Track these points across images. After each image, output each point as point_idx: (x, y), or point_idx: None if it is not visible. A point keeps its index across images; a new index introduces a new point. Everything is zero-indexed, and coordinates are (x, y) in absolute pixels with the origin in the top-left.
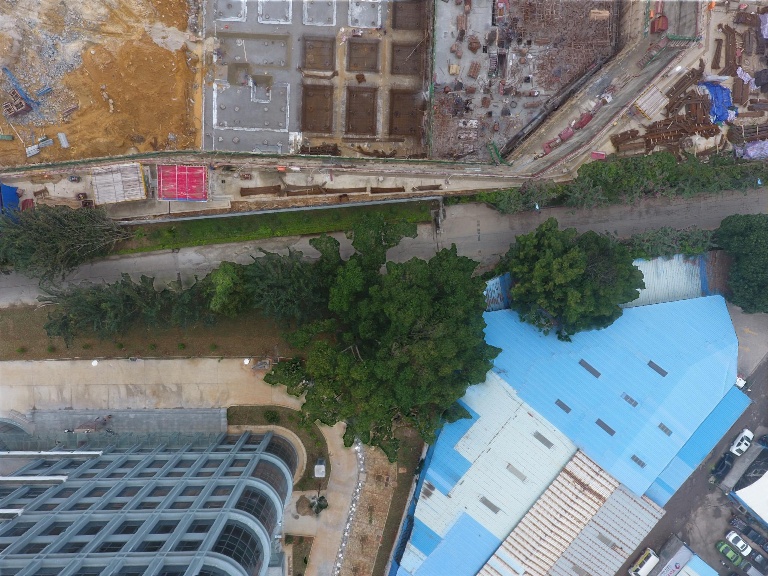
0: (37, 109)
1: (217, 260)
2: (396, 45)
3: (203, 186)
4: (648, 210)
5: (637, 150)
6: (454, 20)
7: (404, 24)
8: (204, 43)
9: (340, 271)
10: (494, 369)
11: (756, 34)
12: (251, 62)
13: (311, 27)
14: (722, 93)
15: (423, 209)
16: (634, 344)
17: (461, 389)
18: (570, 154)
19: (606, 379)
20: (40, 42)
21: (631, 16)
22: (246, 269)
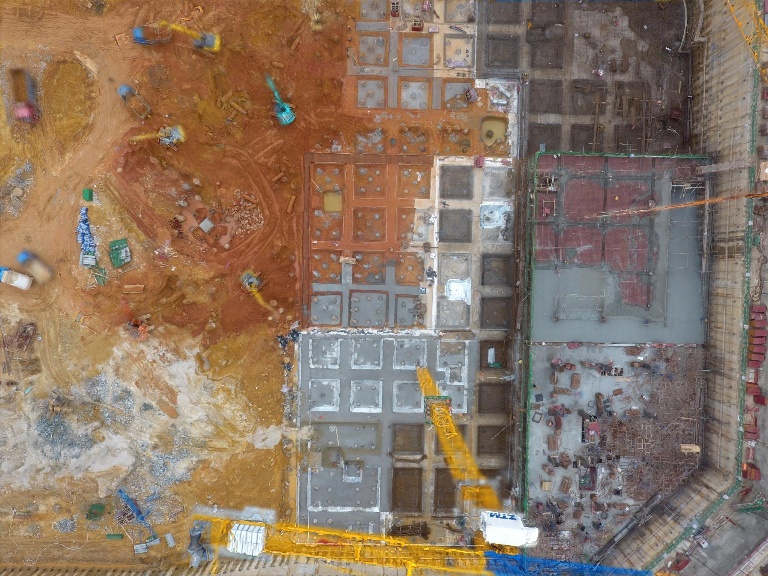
0: (146, 513)
1: None
2: (482, 426)
3: None
4: None
5: None
6: (545, 439)
7: (489, 405)
8: (299, 431)
9: None
10: None
11: None
12: (343, 446)
13: (401, 415)
14: None
15: None
16: None
17: None
18: None
19: None
20: (151, 460)
21: (720, 447)
22: None
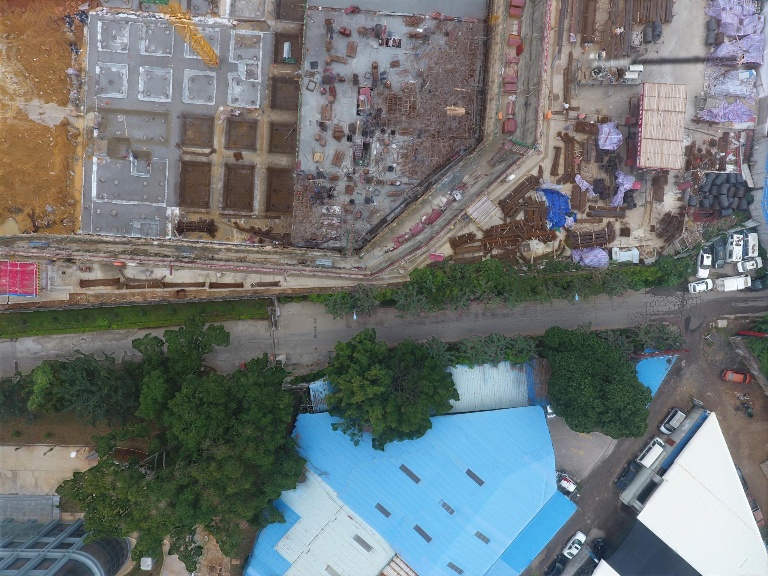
0: None
1: (54, 350)
2: (275, 124)
3: (34, 282)
4: (484, 312)
5: (475, 253)
6: (319, 109)
7: (284, 104)
8: (85, 118)
9: (145, 381)
10: (316, 471)
11: (595, 142)
12: (132, 137)
13: (190, 105)
14: (559, 200)
15: (257, 307)
16: (454, 451)
17: (260, 501)
18: (408, 255)
19: (426, 485)
20: None
21: (488, 113)
22: (66, 368)
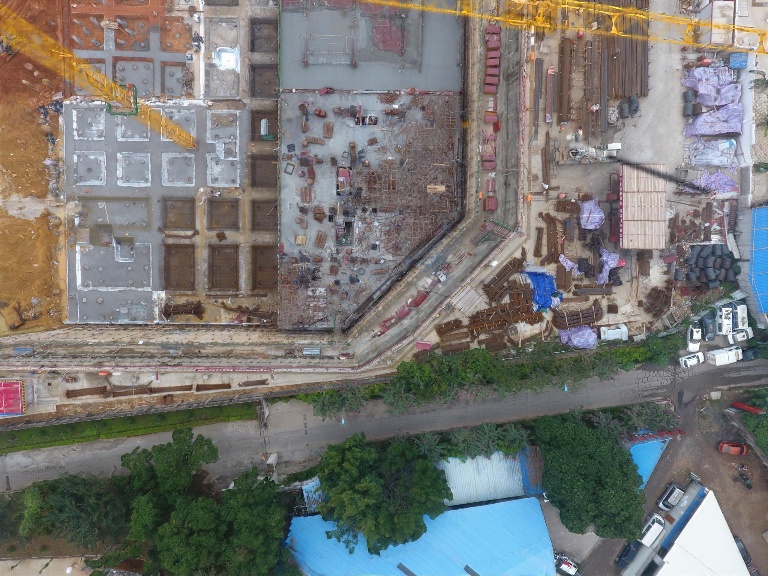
0: None
1: (45, 462)
2: (256, 202)
3: (19, 401)
4: (475, 398)
5: (462, 339)
6: (299, 191)
7: (264, 180)
8: (65, 207)
9: (134, 505)
10: (313, 574)
11: (577, 221)
12: (113, 223)
13: (170, 188)
14: (544, 282)
15: (246, 408)
16: (451, 548)
17: None
18: (395, 345)
19: None
20: None
21: (469, 188)
22: (56, 489)
